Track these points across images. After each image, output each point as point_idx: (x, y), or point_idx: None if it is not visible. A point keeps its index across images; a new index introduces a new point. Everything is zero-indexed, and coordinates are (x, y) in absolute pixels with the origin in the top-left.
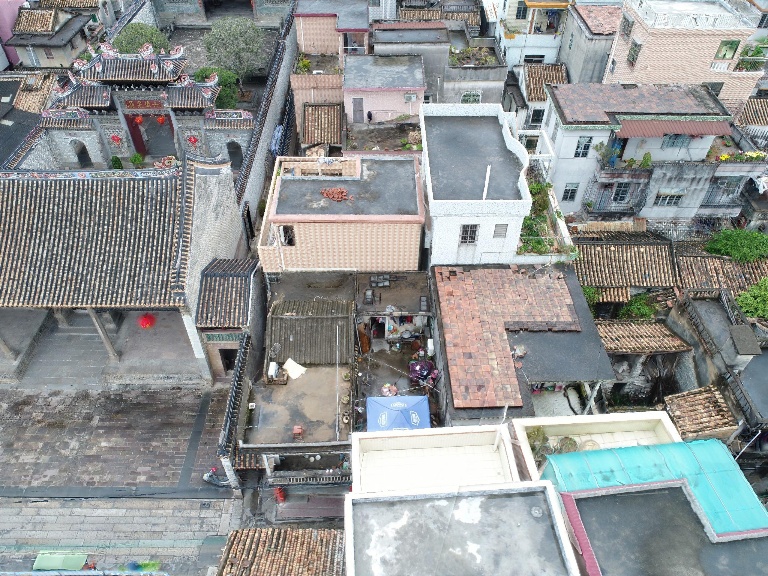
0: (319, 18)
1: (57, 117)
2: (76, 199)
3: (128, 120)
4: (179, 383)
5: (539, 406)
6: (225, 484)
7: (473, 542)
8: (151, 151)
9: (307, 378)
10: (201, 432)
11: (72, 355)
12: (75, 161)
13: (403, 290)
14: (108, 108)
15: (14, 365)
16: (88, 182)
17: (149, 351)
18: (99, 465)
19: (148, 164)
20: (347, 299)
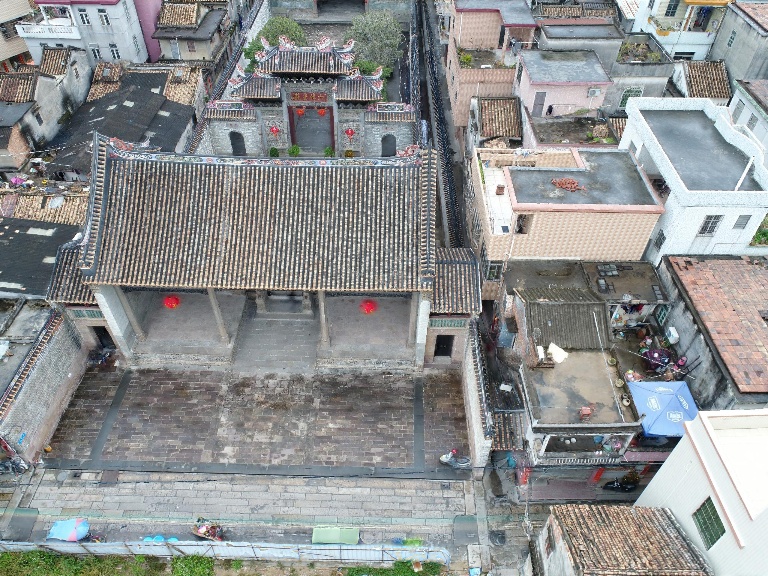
0: (480, 13)
1: (222, 108)
2: (316, 186)
3: (290, 112)
4: (389, 368)
5: None
6: (463, 466)
7: None
8: (298, 143)
9: (572, 362)
10: (422, 416)
11: (276, 339)
12: (230, 152)
13: (633, 279)
14: (274, 100)
15: (229, 348)
16: (328, 169)
17: (356, 336)
18: (332, 445)
19: None
20: (581, 287)
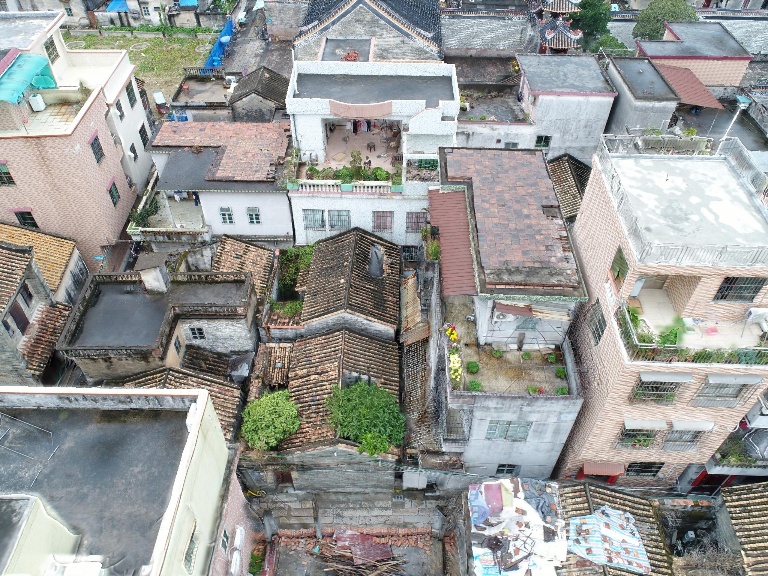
0: None
1: None
2: None
3: None
4: None
5: (198, 215)
6: None
7: (22, 37)
8: None
9: None
10: None
11: None
12: None
13: None
14: None
15: None
16: None
17: None
18: None
19: None
20: None
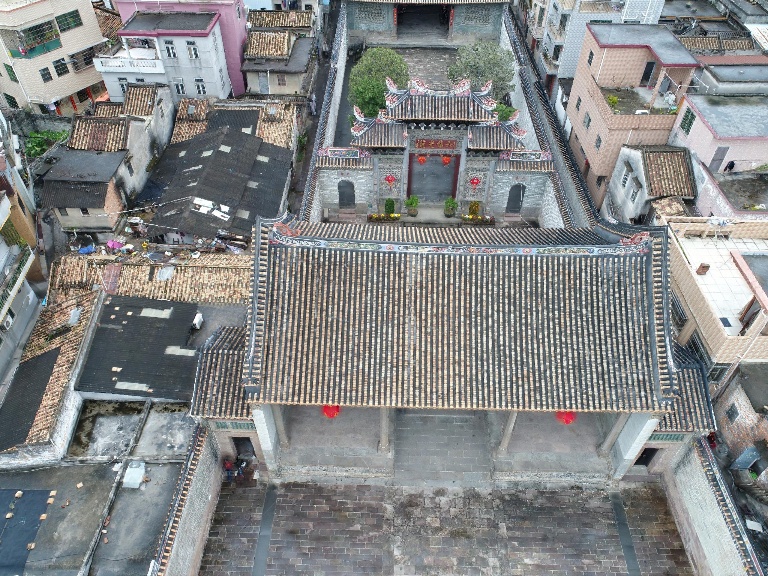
0: (625, 49)
1: (334, 156)
2: (518, 278)
3: (411, 160)
4: (578, 481)
5: None
6: None
7: None
8: None
9: None
10: (632, 547)
11: (437, 442)
12: (337, 202)
13: None
14: (397, 148)
15: (390, 458)
16: (532, 259)
17: (536, 442)
18: None
19: (416, 206)
20: None
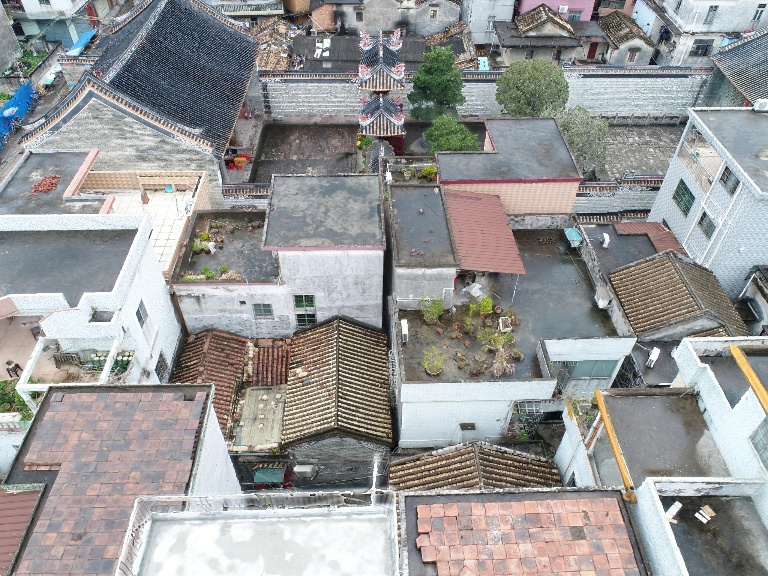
0: None
1: None
2: None
3: None
4: None
5: None
6: None
7: None
8: None
9: None
10: None
11: None
12: None
13: None
14: None
15: None
16: None
17: None
18: None
19: None
20: None
